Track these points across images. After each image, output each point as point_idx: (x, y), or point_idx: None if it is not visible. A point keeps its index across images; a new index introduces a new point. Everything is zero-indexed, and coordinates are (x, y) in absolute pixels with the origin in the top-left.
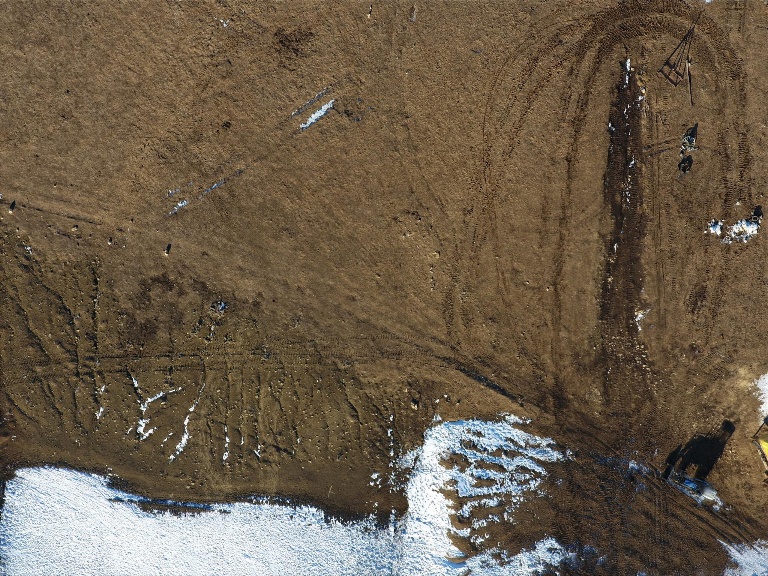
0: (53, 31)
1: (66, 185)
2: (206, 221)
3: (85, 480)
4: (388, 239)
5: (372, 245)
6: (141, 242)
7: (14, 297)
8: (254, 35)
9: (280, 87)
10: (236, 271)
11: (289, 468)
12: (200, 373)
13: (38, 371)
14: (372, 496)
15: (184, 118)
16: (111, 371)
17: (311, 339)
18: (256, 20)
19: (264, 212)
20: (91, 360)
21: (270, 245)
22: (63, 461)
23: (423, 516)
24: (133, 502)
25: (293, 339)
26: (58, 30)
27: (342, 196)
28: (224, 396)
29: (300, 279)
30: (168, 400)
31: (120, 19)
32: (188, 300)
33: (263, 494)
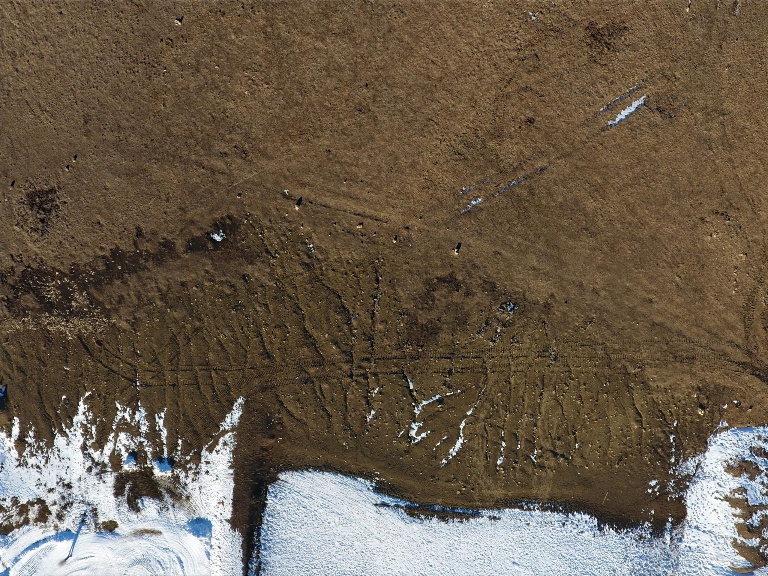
0: (357, 22)
1: (356, 181)
2: (501, 219)
3: (351, 484)
4: (693, 240)
5: (675, 246)
6: (429, 240)
7: (292, 296)
8: (564, 28)
9: (589, 82)
10: (529, 271)
11: (564, 474)
12: (482, 376)
13: (311, 372)
14: (649, 503)
15: (485, 113)
16: (387, 373)
17: (602, 342)
18: (567, 13)
19: (564, 211)
20: (367, 361)
21: (568, 245)
22: (328, 464)
23: (702, 524)
24: (400, 507)
25: (583, 342)
26: (362, 21)
27: (648, 195)
28: (505, 399)
29: (596, 280)
30: (445, 403)
31: (427, 11)
32: (475, 300)
33: (535, 500)
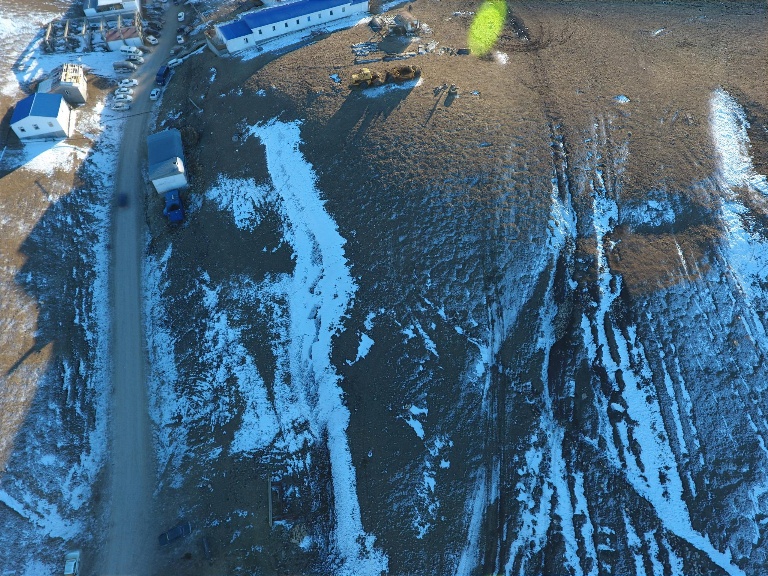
0: None
1: None
2: None
3: None
4: None
5: None
6: None
7: None
8: None
9: None
10: None
11: None
12: None
13: None
14: None
15: None
16: None
17: None
18: None
19: None
20: None
21: None
22: None
23: None
24: None
25: None
26: None
27: None
28: None
29: (637, 6)
30: None
31: None
32: (682, 3)
33: None
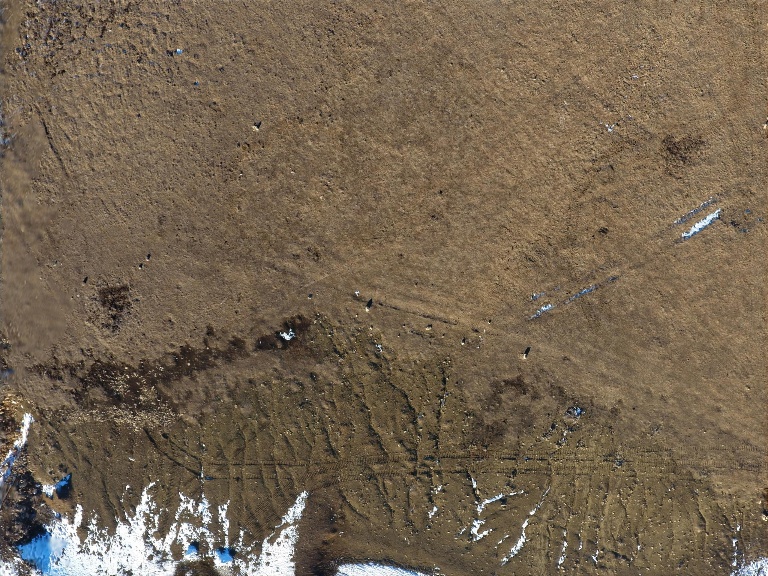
0: (433, 131)
1: (427, 285)
2: (571, 326)
3: None
4: (763, 352)
5: (745, 357)
6: (497, 344)
7: (359, 394)
8: (640, 141)
9: (664, 195)
10: (598, 378)
11: (625, 574)
12: (546, 477)
13: (375, 469)
14: None
15: (558, 222)
16: (451, 471)
17: (668, 448)
18: (643, 126)
19: (635, 320)
20: (431, 459)
21: (637, 353)
22: (389, 558)
23: None
24: None
25: (649, 447)
26: (439, 131)
27: (720, 307)
28: (569, 501)
29: (665, 388)
30: (508, 503)
31: (504, 121)
32: (542, 404)
33: None
